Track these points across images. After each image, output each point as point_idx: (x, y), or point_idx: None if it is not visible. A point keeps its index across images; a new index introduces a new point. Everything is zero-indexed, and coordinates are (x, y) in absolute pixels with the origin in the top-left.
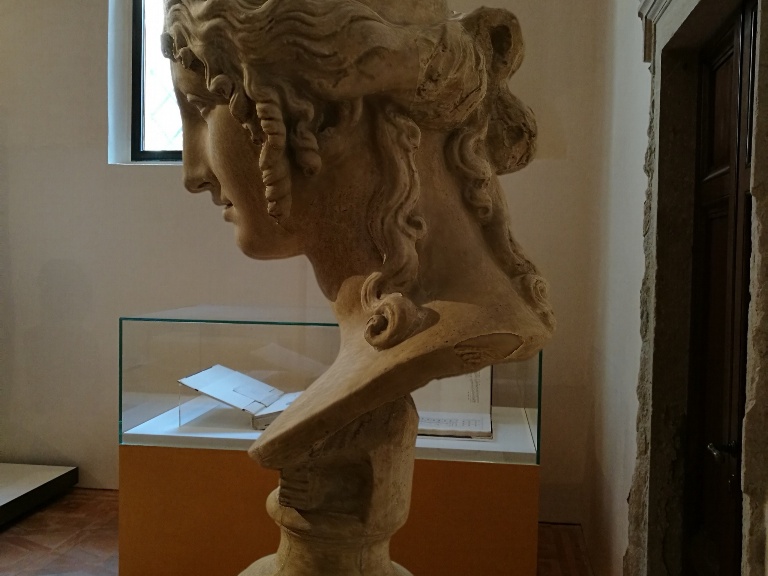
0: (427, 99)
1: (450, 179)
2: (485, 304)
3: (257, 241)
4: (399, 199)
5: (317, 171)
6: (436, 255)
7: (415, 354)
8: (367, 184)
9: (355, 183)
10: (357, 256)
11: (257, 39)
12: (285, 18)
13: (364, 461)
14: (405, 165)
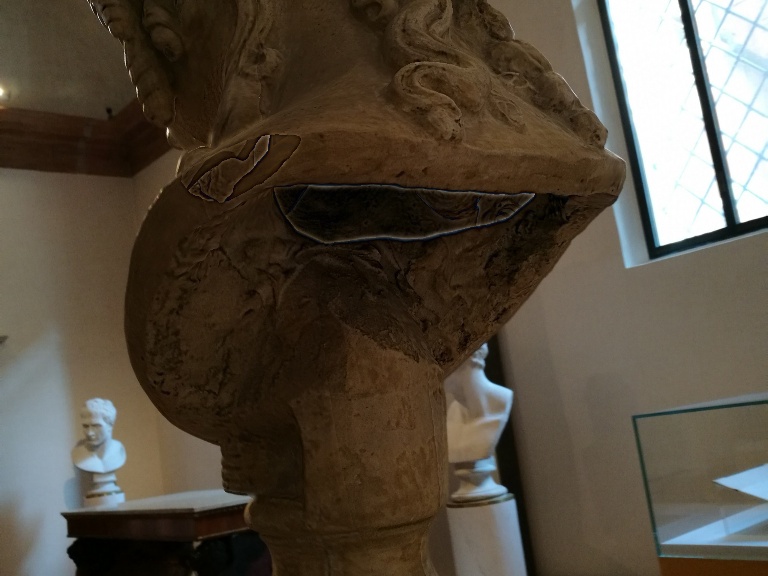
0: None
1: None
2: (278, 114)
3: None
4: (241, 36)
5: (174, 49)
6: (289, 89)
7: None
8: None
9: (224, 47)
10: None
11: None
12: None
13: (292, 417)
14: None
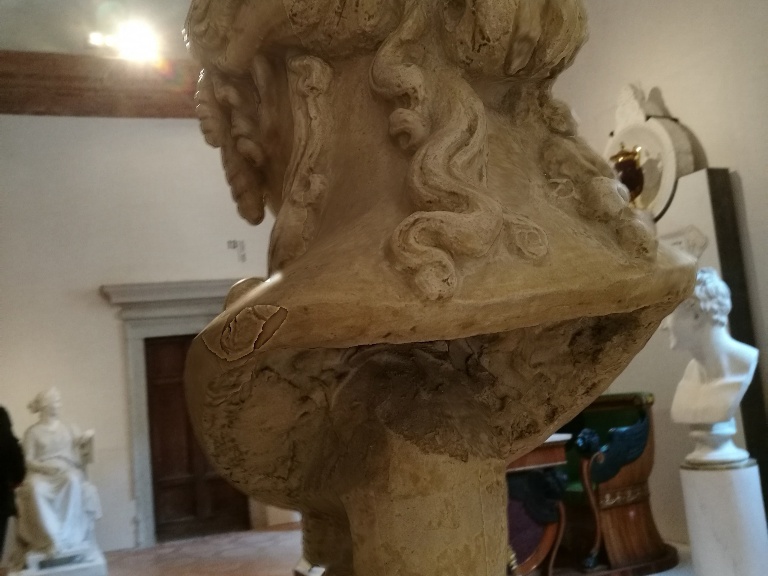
0: (308, 23)
1: (376, 111)
2: (288, 270)
3: None
4: (295, 160)
5: (254, 157)
6: (327, 218)
7: None
8: None
9: None
10: None
11: (189, 46)
12: None
13: None
14: (302, 115)
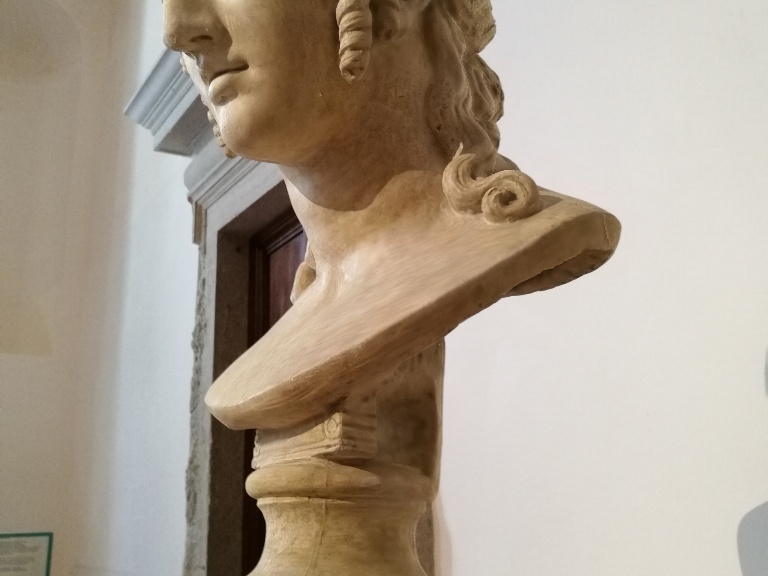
0: (472, 11)
1: None
2: None
3: (282, 116)
4: (464, 93)
5: (394, 37)
6: None
7: (576, 214)
8: (422, 75)
9: (412, 70)
10: (415, 148)
11: None
12: None
13: (426, 394)
14: None
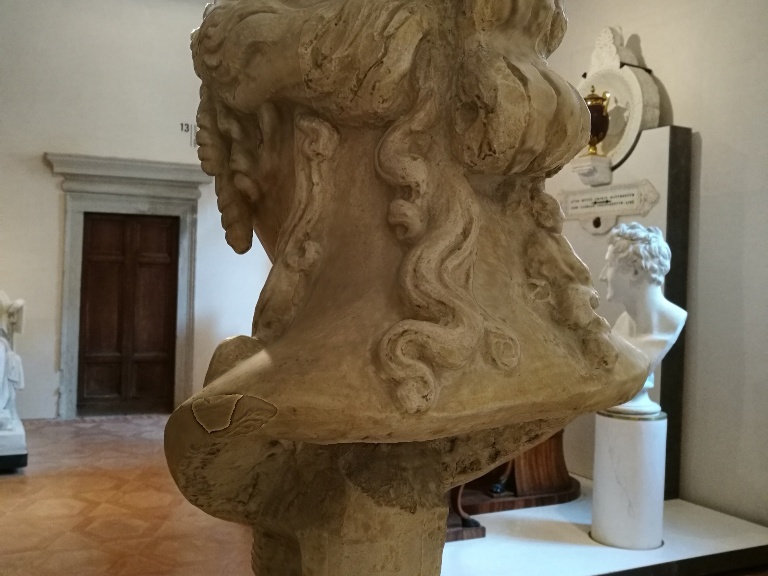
0: (322, 91)
1: (377, 189)
2: (279, 356)
3: None
4: (293, 220)
5: (250, 195)
6: (318, 290)
7: None
8: None
9: (289, 205)
10: None
11: (196, 65)
12: (204, 37)
13: None
14: (305, 178)
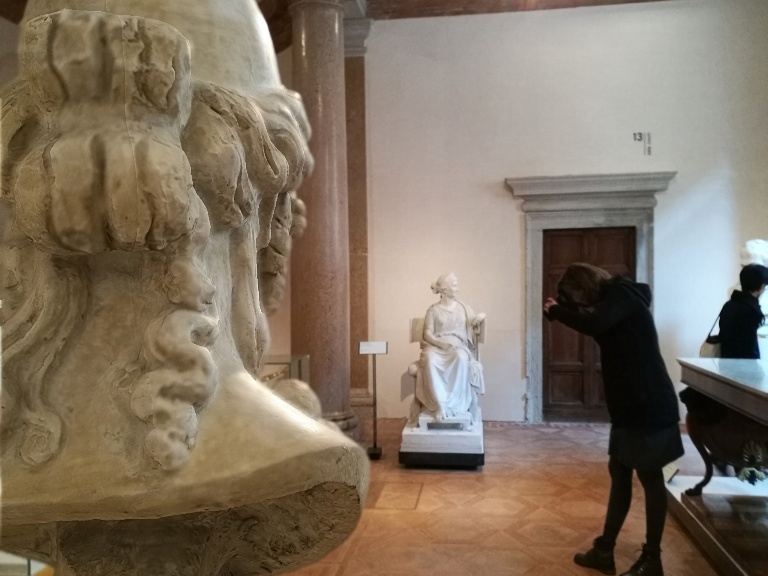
0: None
1: None
2: None
3: None
4: None
5: None
6: None
7: None
8: None
9: None
10: None
11: None
12: None
13: None
14: None
